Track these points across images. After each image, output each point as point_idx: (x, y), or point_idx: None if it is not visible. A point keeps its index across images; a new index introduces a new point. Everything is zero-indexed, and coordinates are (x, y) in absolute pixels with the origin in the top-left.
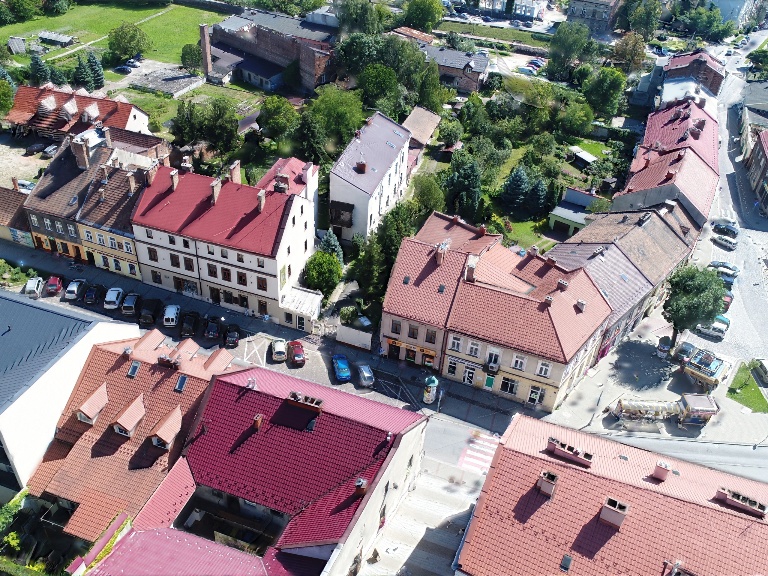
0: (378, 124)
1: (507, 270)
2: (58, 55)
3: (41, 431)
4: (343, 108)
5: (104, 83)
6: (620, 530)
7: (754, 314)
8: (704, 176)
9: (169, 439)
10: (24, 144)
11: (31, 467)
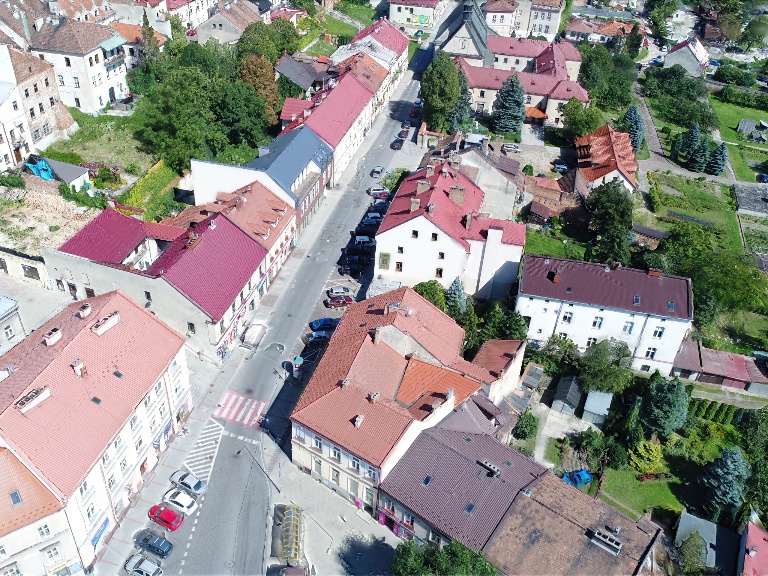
0: (665, 283)
1: (432, 388)
2: (763, 148)
3: (214, 191)
4: (710, 269)
5: (722, 174)
6: None
7: None
8: None
9: (197, 221)
10: (569, 159)
11: (204, 202)
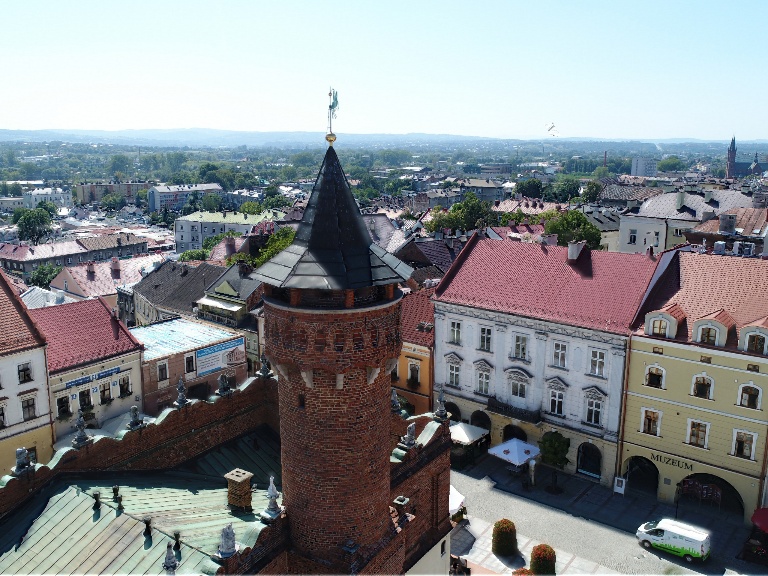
0: None
1: None
2: None
3: None
4: None
5: None
6: (121, 270)
7: None
8: None
9: None
10: None
11: None
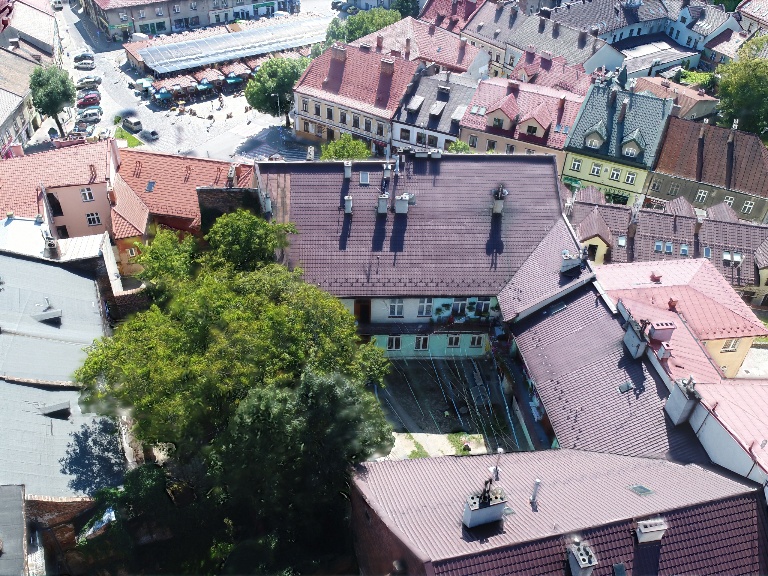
0: None
1: None
2: None
3: None
4: None
5: None
6: (1, 187)
7: (119, 99)
8: (39, 19)
9: None
10: None
11: None
